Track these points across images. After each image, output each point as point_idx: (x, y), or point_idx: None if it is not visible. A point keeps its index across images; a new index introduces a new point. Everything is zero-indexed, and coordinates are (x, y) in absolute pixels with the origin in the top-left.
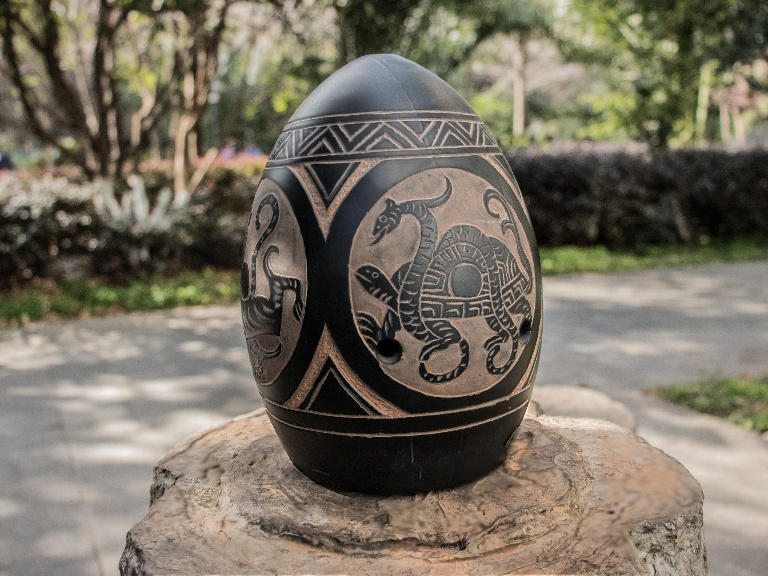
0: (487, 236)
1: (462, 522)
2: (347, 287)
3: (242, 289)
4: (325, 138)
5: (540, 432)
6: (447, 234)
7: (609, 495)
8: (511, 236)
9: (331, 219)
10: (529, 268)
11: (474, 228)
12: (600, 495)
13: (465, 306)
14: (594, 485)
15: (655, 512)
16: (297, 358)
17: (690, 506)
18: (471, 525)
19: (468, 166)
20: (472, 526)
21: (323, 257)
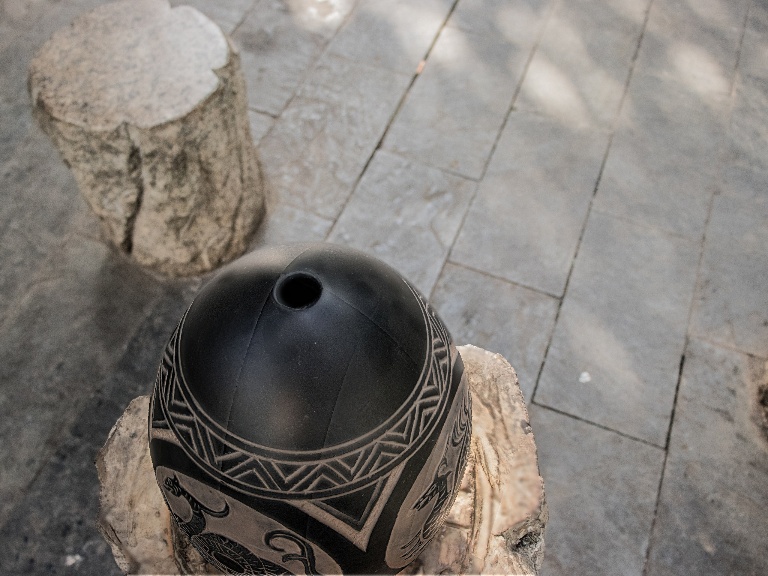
0: (258, 556)
1: None
2: None
3: None
4: None
5: (434, 573)
6: (213, 535)
7: None
8: (298, 564)
9: None
10: None
11: (242, 547)
12: None
13: (227, 569)
14: None
15: None
16: None
17: None
18: None
19: (258, 507)
20: None
21: None
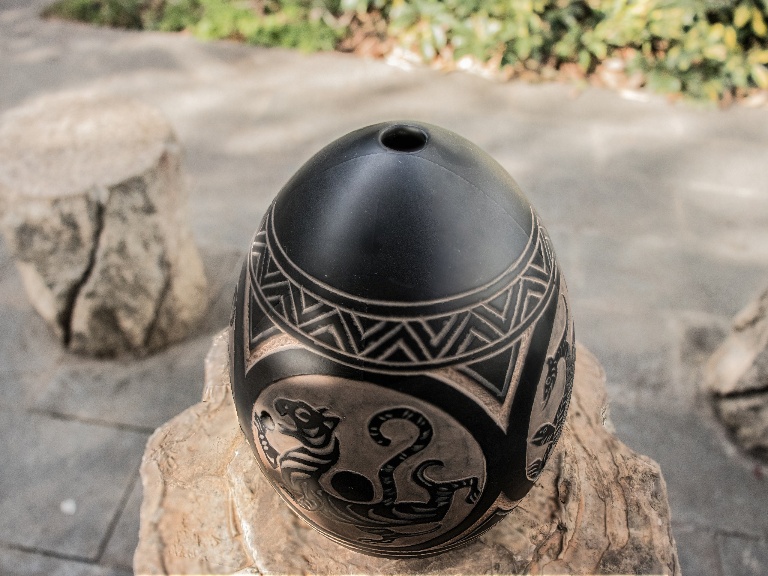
0: None
1: (538, 506)
2: (525, 456)
3: (337, 491)
4: (473, 328)
5: None
6: None
7: None
8: None
9: (507, 411)
10: None
11: None
12: None
13: None
14: None
15: (597, 396)
16: (461, 525)
17: (603, 374)
18: (546, 504)
19: None
20: (547, 504)
21: (504, 448)
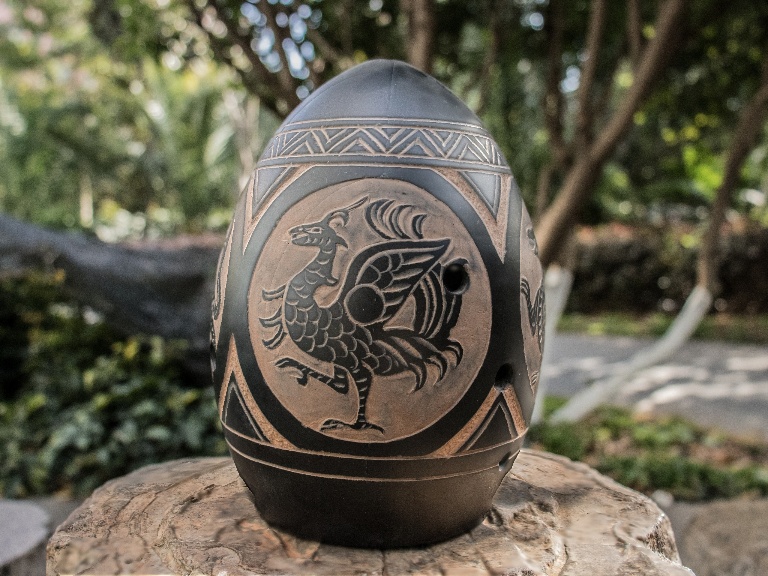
0: None
1: None
2: None
3: None
4: None
5: (309, 575)
6: None
7: (148, 572)
8: None
9: None
10: (220, 293)
11: None
12: (156, 568)
13: None
14: (174, 573)
15: None
16: None
17: None
18: None
19: None
20: None
21: None
